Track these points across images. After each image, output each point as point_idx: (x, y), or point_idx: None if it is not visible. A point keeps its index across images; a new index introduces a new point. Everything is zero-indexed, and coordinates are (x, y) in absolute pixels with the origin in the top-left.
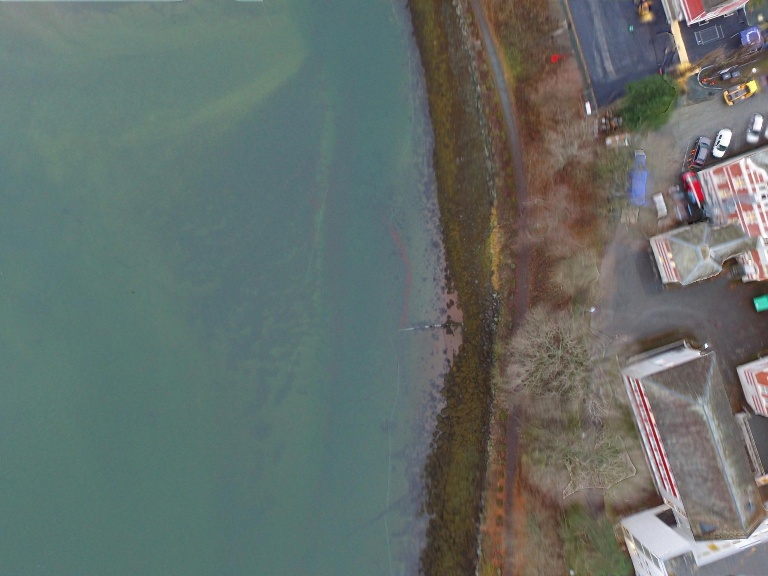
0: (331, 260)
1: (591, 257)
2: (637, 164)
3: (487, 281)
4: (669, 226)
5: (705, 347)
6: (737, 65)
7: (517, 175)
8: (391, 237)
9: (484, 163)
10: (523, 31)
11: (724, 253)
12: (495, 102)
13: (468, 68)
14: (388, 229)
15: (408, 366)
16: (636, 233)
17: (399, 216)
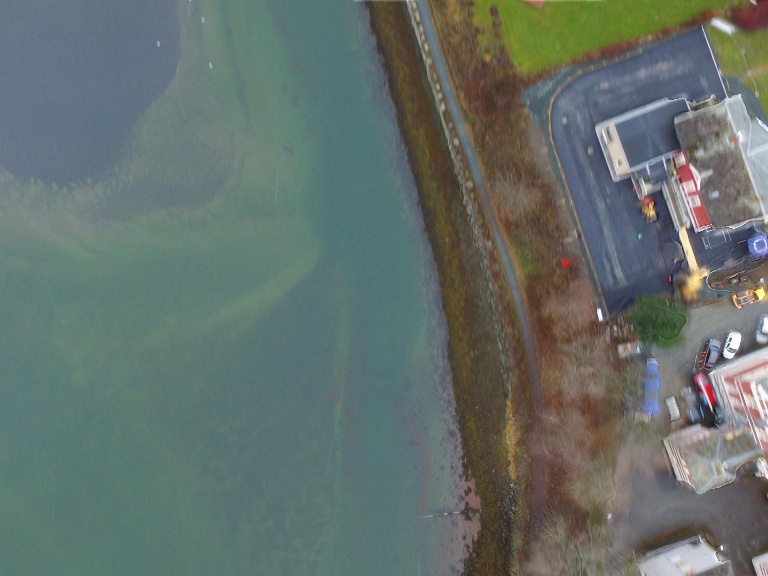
0: (350, 452)
1: (607, 478)
2: (649, 372)
3: (504, 471)
4: (682, 427)
5: (721, 549)
6: (745, 271)
7: (531, 371)
8: (408, 427)
9: (498, 356)
10: (533, 234)
11: (737, 464)
12: (507, 300)
13: (480, 265)
14: (405, 419)
15: (428, 552)
16: (650, 433)
17: (416, 407)
